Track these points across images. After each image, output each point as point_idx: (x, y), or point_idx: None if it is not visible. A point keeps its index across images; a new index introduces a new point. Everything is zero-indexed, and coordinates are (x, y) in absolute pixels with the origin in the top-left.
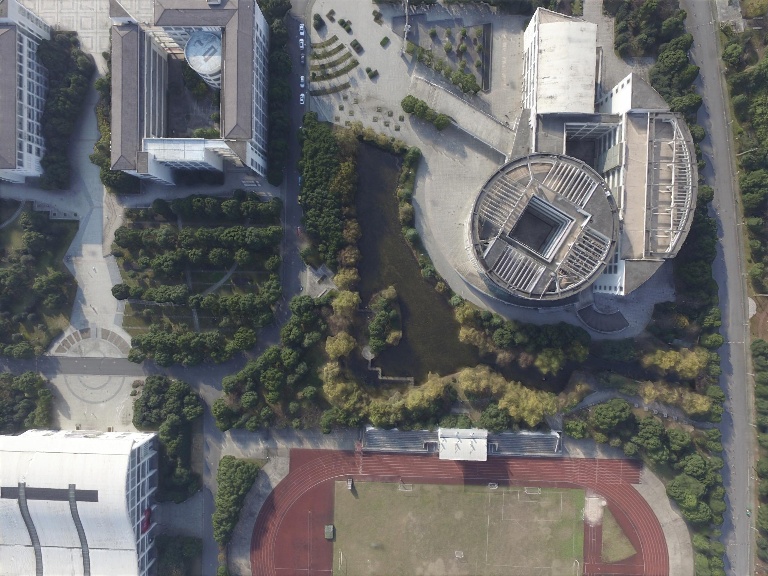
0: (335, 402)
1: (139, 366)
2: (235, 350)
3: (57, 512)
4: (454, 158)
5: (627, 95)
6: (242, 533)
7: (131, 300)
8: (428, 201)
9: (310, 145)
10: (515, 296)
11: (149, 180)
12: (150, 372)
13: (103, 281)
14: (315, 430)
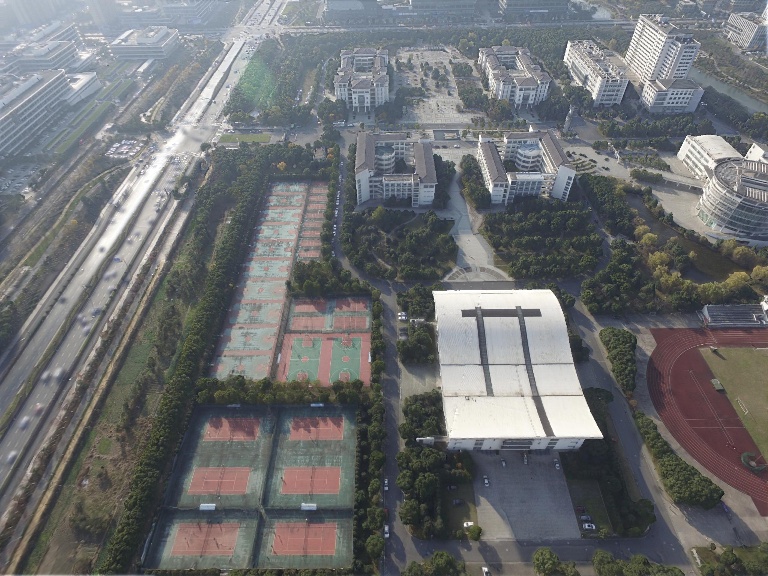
0: (673, 289)
1: (512, 285)
2: (586, 265)
3: (508, 327)
4: None
5: (757, 150)
6: (639, 391)
7: (497, 253)
8: (667, 208)
9: None
10: (763, 218)
11: (494, 205)
12: (521, 288)
13: (475, 245)
14: (662, 316)
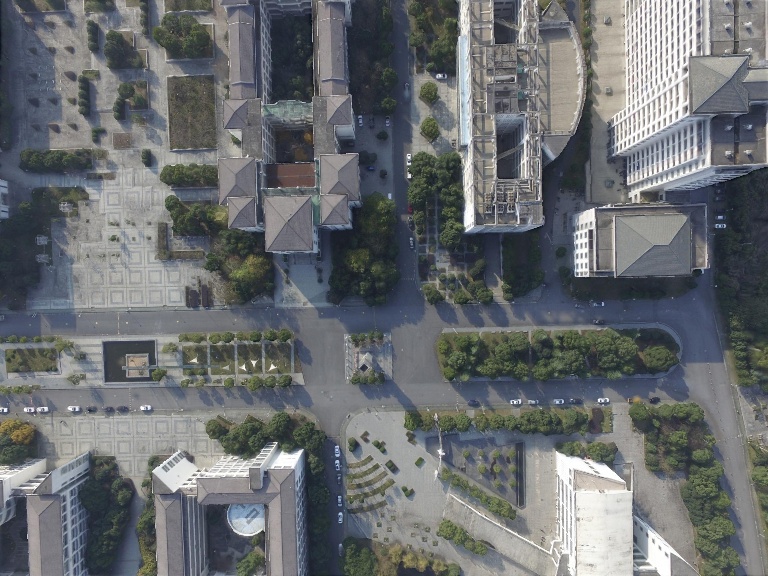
0: None
1: None
2: None
3: None
4: (492, 571)
5: (666, 568)
6: None
7: None
8: None
9: None
10: None
11: None
12: None
13: None
14: None
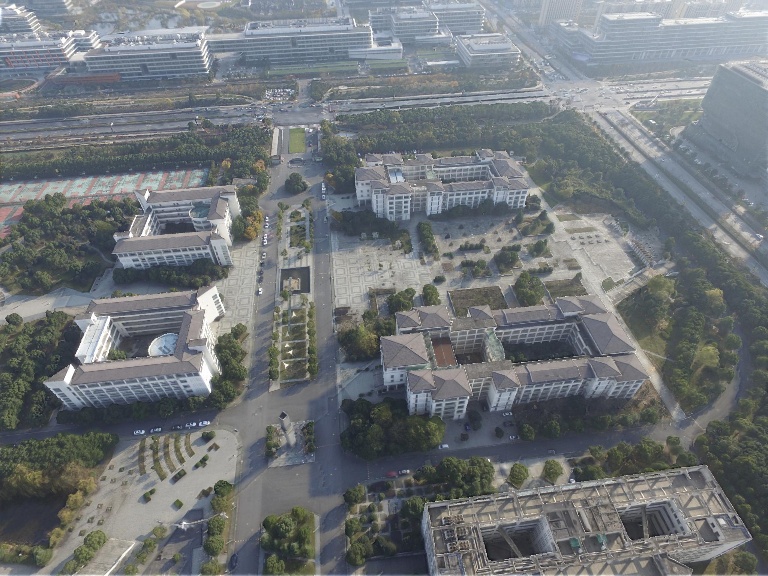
0: None
1: None
2: None
3: None
4: None
5: None
6: None
7: None
8: None
9: (70, 439)
10: None
11: None
12: None
13: (36, 310)
14: None
